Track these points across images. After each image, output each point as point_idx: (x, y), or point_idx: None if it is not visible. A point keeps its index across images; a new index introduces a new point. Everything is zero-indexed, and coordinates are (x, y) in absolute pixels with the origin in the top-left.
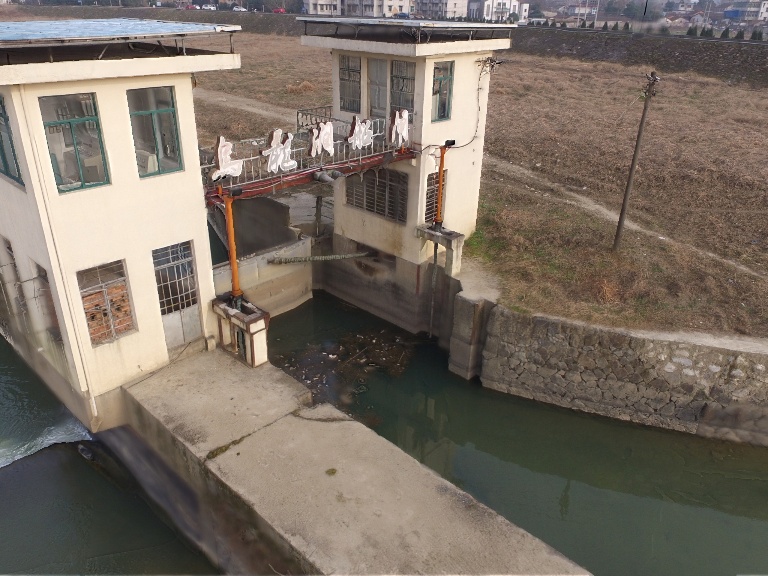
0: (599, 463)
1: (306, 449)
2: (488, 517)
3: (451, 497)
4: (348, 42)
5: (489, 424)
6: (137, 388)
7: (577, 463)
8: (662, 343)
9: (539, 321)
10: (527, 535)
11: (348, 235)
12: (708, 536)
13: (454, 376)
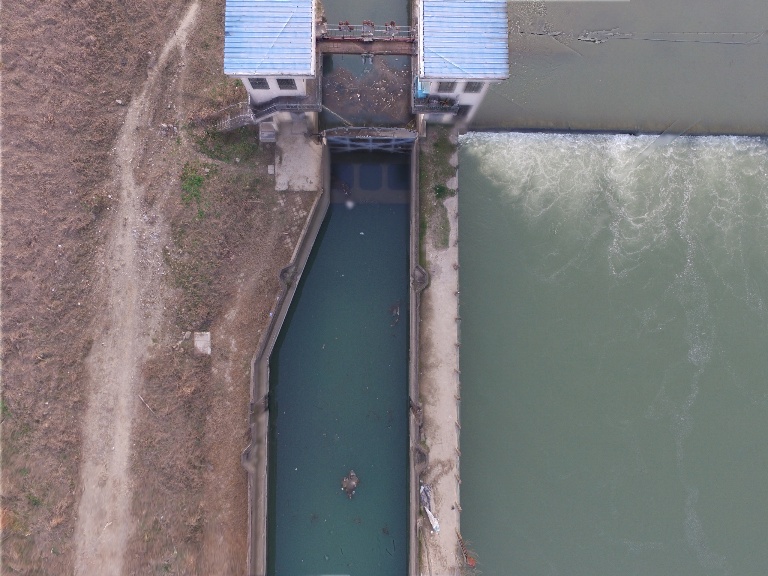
0: None
1: None
2: None
3: None
4: None
5: None
6: None
7: None
8: None
9: None
10: None
11: None
12: None
13: None
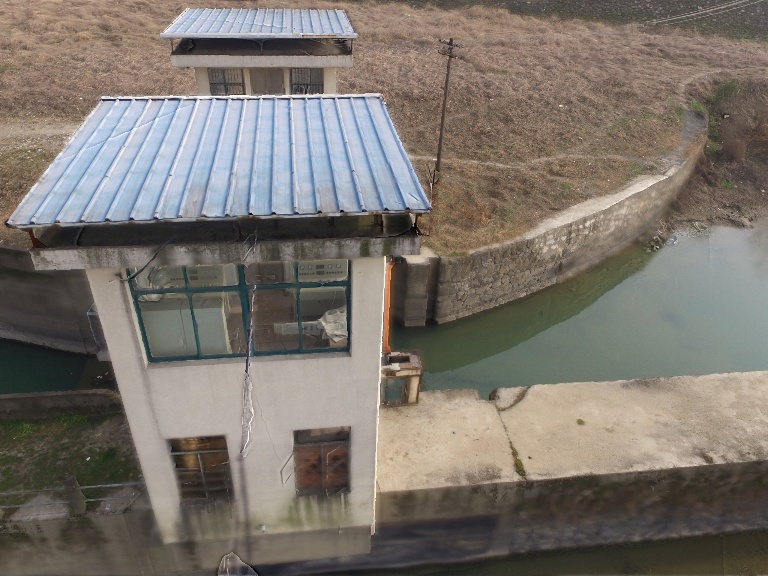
0: (510, 333)
1: (548, 422)
2: (659, 383)
3: (635, 387)
4: (255, 59)
5: (443, 350)
6: (385, 484)
7: (497, 341)
8: (541, 236)
9: (476, 256)
10: (680, 377)
11: None
12: (617, 335)
13: (412, 329)
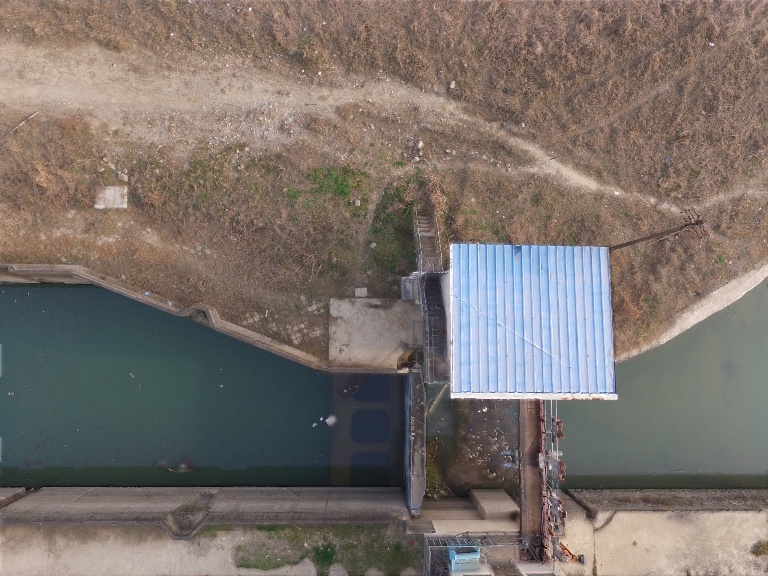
0: None
1: (618, 542)
2: (689, 516)
3: (674, 518)
4: None
5: None
6: None
7: None
8: None
9: None
10: (703, 513)
11: None
12: (685, 381)
13: None
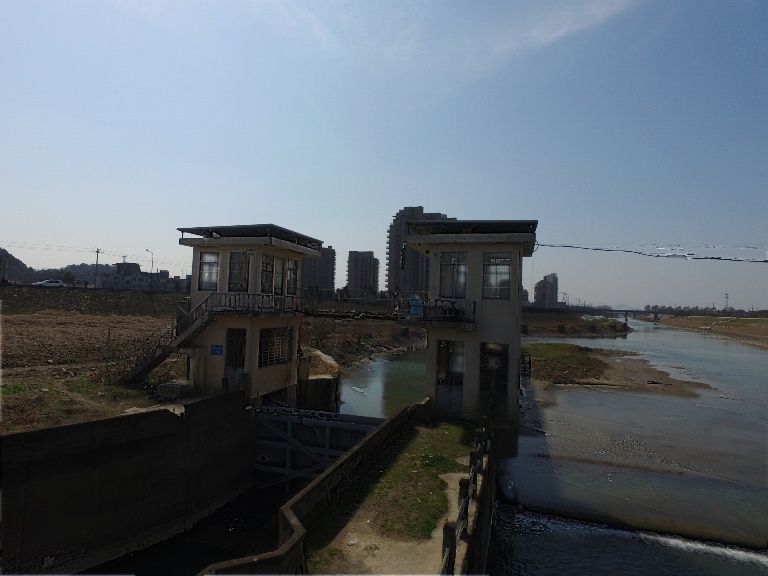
0: None
1: None
2: None
3: None
4: None
5: None
6: None
7: None
8: None
9: None
10: None
11: (261, 393)
12: None
13: None
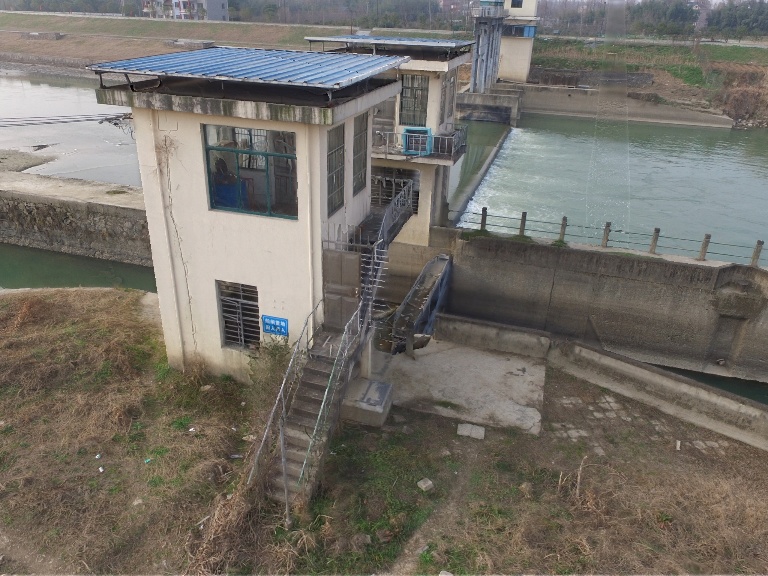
0: None
1: None
2: None
3: None
4: None
5: None
6: None
7: None
8: None
9: None
10: None
11: None
12: None
13: None
